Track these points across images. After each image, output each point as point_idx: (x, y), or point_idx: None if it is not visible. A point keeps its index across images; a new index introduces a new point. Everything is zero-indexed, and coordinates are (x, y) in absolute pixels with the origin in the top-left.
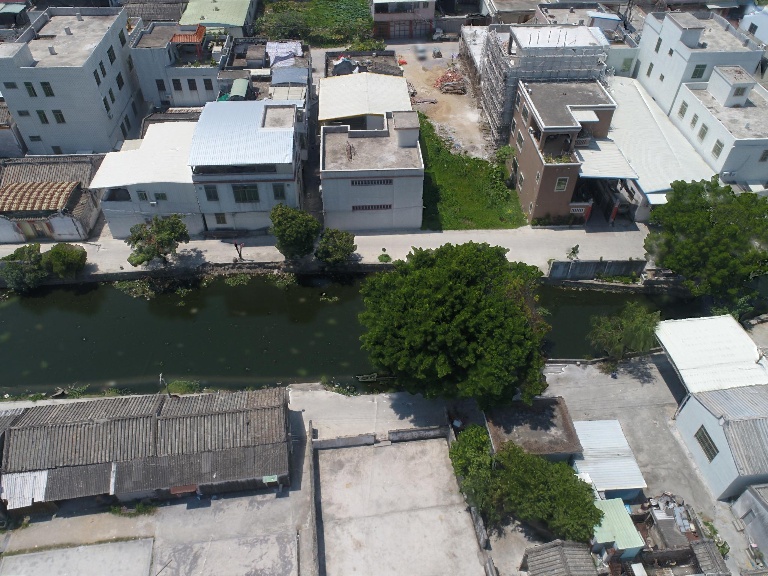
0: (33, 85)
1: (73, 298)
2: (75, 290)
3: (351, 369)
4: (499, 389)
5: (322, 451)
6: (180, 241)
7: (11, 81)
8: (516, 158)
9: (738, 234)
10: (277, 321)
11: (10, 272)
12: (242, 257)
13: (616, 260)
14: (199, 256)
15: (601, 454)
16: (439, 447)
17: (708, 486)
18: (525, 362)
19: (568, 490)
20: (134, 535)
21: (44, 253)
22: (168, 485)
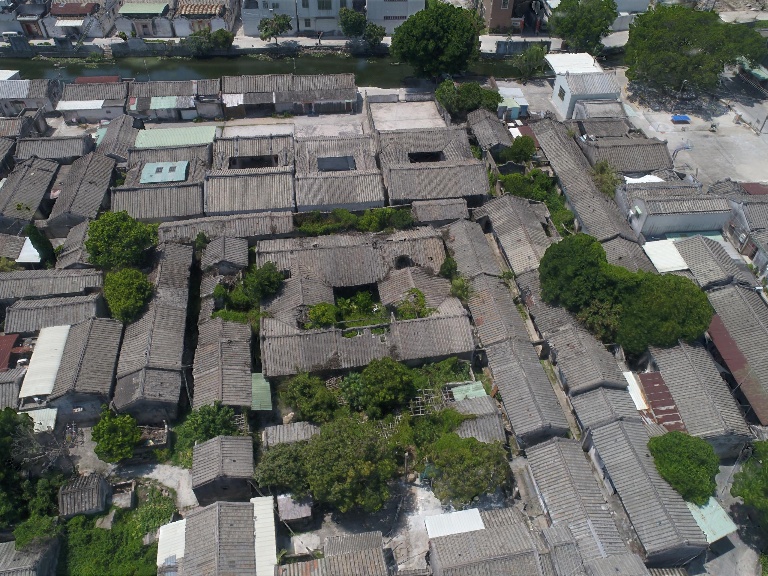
0: None
1: (227, 60)
2: (227, 57)
3: (384, 85)
4: (458, 53)
5: (371, 103)
6: (287, 29)
7: None
8: (482, 1)
9: (592, 11)
10: (343, 69)
11: (195, 41)
12: (320, 43)
13: (533, 41)
14: (296, 43)
15: (509, 96)
16: (430, 104)
17: (563, 115)
18: (471, 41)
19: (488, 92)
20: None
21: (212, 33)
22: (300, 101)
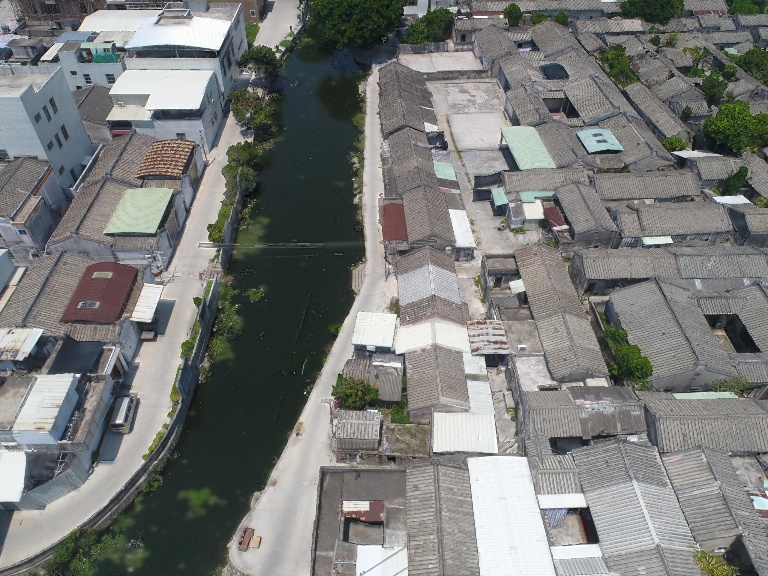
0: (47, 107)
1: (266, 171)
2: None
3: (351, 79)
4: None
5: None
6: None
7: (37, 113)
8: None
9: None
10: (311, 97)
11: (249, 174)
12: None
13: None
14: None
15: None
16: (403, 56)
17: None
18: None
19: None
20: (446, 119)
21: None
22: (429, 97)
